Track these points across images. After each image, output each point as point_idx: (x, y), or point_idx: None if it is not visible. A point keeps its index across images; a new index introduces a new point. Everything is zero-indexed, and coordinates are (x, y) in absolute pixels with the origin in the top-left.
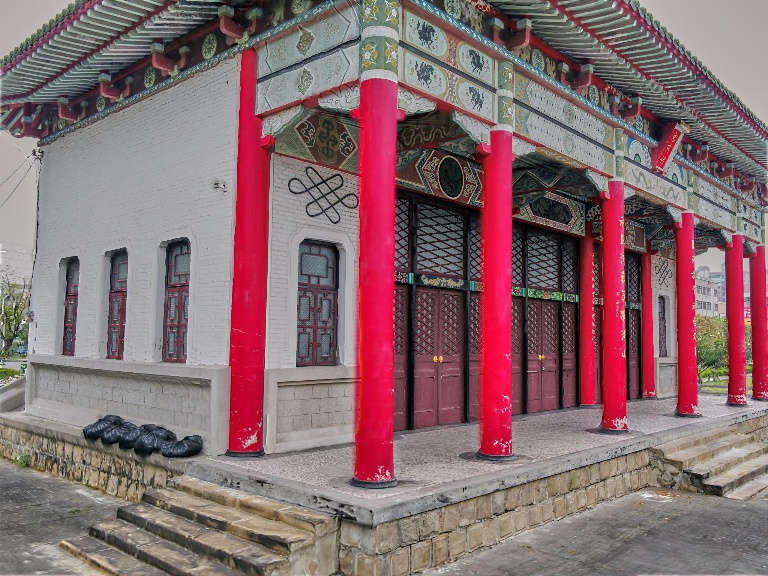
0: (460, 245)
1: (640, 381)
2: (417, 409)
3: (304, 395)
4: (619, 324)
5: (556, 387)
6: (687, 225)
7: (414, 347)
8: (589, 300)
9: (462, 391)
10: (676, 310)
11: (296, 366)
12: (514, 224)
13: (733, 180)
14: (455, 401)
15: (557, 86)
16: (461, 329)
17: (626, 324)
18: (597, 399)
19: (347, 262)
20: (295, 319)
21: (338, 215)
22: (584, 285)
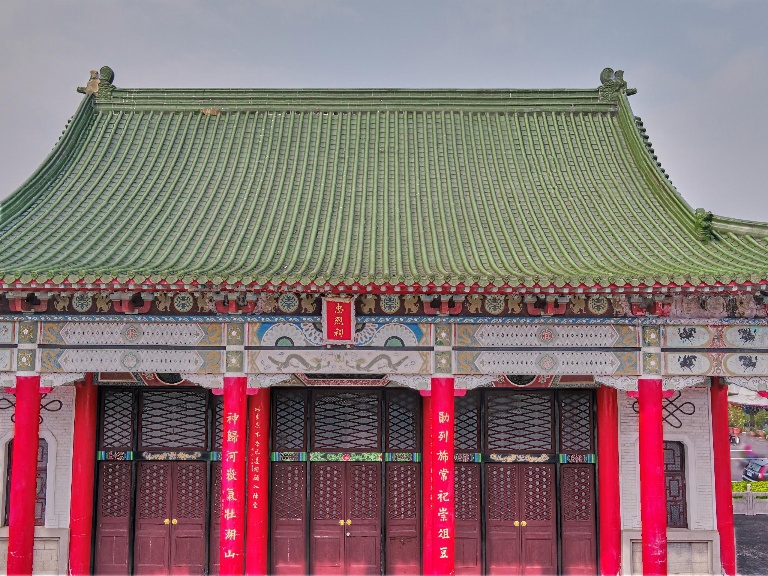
0: (201, 420)
1: (597, 559)
2: (143, 563)
3: (7, 546)
4: (223, 523)
5: (376, 555)
6: (434, 393)
7: (140, 511)
8: (427, 460)
9: (204, 551)
10: (711, 460)
11: (7, 525)
12: (288, 390)
13: (626, 301)
14: (195, 559)
15: (95, 320)
16: (204, 495)
17: (555, 482)
18: (474, 575)
19: (49, 451)
20: (0, 494)
21: (41, 418)
22: (424, 442)
